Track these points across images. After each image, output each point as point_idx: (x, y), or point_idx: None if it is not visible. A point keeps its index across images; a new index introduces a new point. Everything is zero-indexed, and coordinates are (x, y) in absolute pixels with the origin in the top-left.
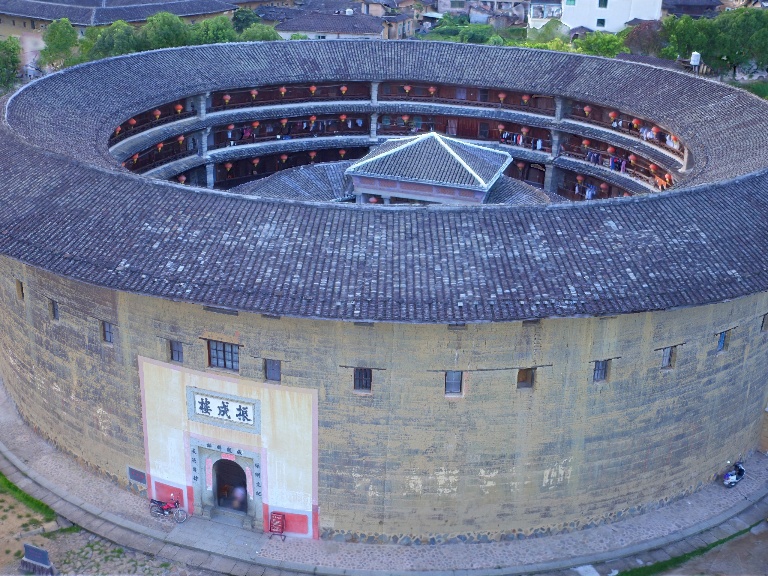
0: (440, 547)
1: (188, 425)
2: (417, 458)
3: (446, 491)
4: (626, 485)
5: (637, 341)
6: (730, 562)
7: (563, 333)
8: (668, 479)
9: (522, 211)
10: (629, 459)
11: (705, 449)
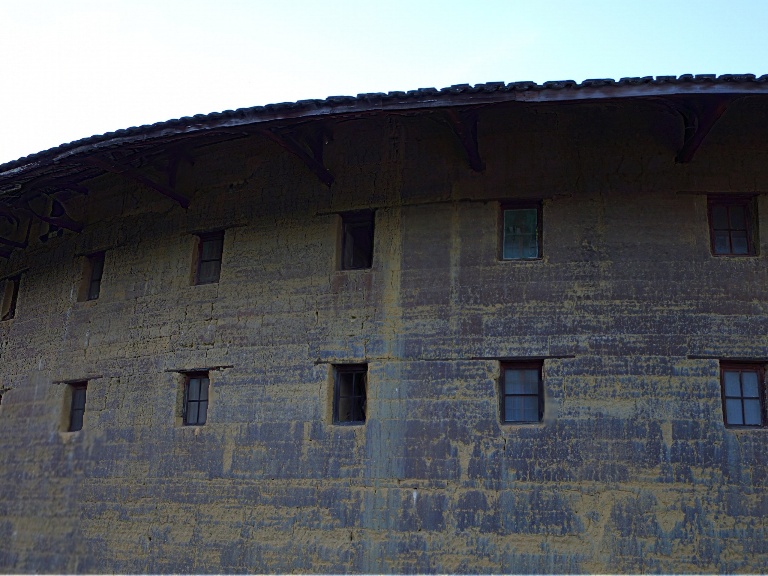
0: None
1: None
2: None
3: None
4: None
5: None
6: None
7: None
8: None
9: None
10: None
11: None
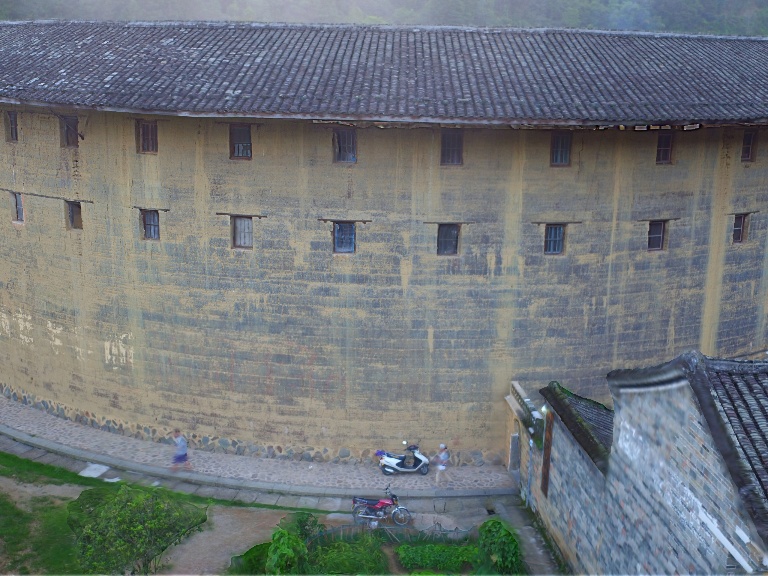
0: (27, 408)
1: None
2: (4, 292)
3: (27, 340)
4: (208, 400)
5: (189, 193)
6: (239, 522)
7: (99, 162)
8: (276, 418)
9: (102, 26)
10: (205, 362)
11: (343, 399)
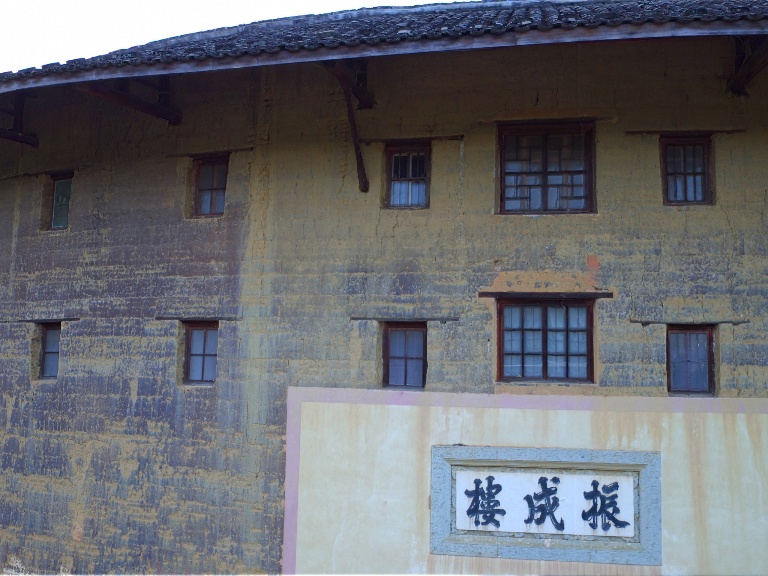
0: None
1: (429, 572)
2: None
3: None
4: None
5: None
6: None
7: None
8: None
9: None
10: None
11: None
